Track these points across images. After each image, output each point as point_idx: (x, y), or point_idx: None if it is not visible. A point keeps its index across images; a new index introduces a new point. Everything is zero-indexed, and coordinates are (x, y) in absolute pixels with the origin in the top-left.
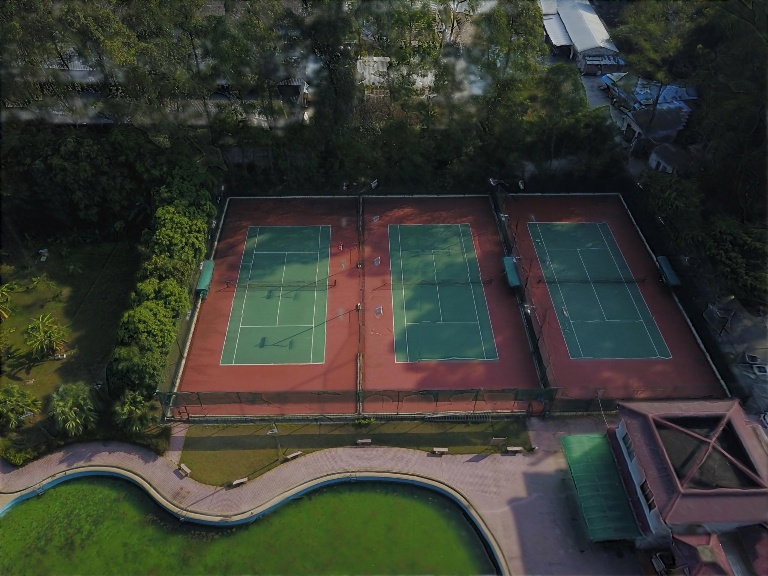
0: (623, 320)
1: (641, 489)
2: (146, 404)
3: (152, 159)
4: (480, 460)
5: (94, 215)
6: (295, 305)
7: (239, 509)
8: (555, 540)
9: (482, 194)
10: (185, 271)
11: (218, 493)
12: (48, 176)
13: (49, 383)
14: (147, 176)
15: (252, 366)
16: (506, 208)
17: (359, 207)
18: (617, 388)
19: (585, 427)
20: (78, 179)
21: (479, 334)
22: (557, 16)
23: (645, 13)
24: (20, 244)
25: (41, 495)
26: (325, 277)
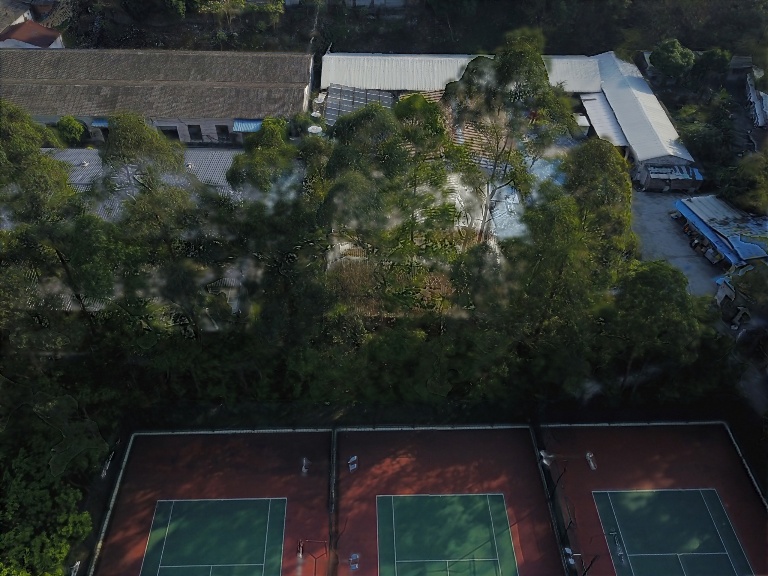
0: None
1: None
2: None
3: None
4: None
5: None
6: None
7: None
8: None
9: (519, 424)
10: None
11: None
12: None
13: None
14: None
15: None
16: None
17: (332, 456)
18: None
19: None
20: None
21: None
22: (602, 96)
23: None
24: None
25: None
26: None
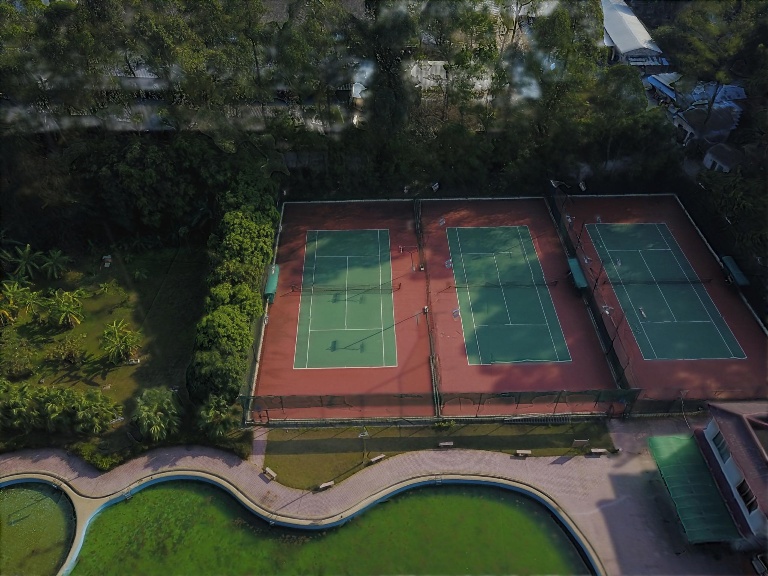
0: (693, 321)
1: (738, 490)
2: (230, 408)
3: (216, 165)
4: (564, 462)
5: (157, 221)
6: (362, 309)
7: (328, 512)
8: (649, 542)
9: (537, 196)
10: (256, 275)
11: (305, 497)
12: (114, 183)
13: (126, 388)
14: (211, 182)
15: (326, 370)
16: (566, 210)
17: (415, 210)
18: (695, 389)
19: (666, 428)
20: (143, 185)
21: (549, 336)
22: None
23: (702, 13)
24: (83, 251)
25: (129, 499)
26: (389, 280)
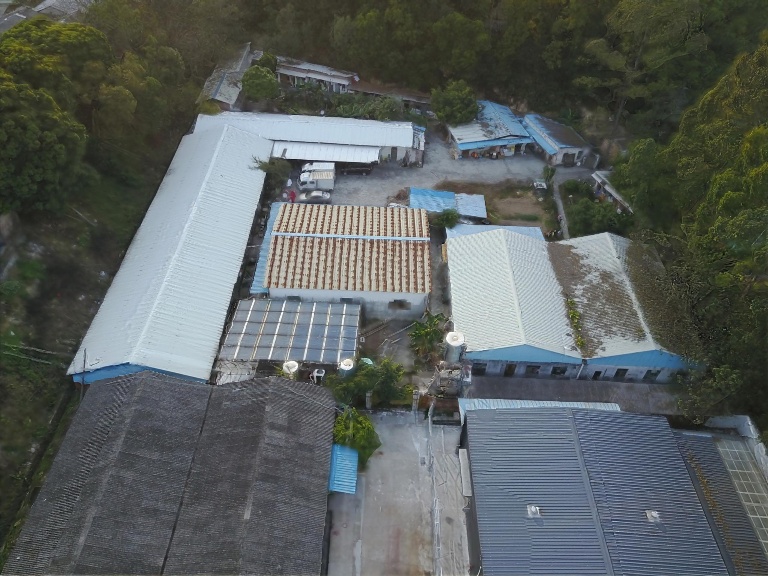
0: None
1: None
2: None
3: None
4: None
5: None
6: None
7: None
8: None
9: None
10: None
11: None
12: None
13: None
14: None
15: None
16: None
17: None
18: None
19: None
20: None
21: None
22: (282, 143)
23: None
24: None
25: None
26: None
